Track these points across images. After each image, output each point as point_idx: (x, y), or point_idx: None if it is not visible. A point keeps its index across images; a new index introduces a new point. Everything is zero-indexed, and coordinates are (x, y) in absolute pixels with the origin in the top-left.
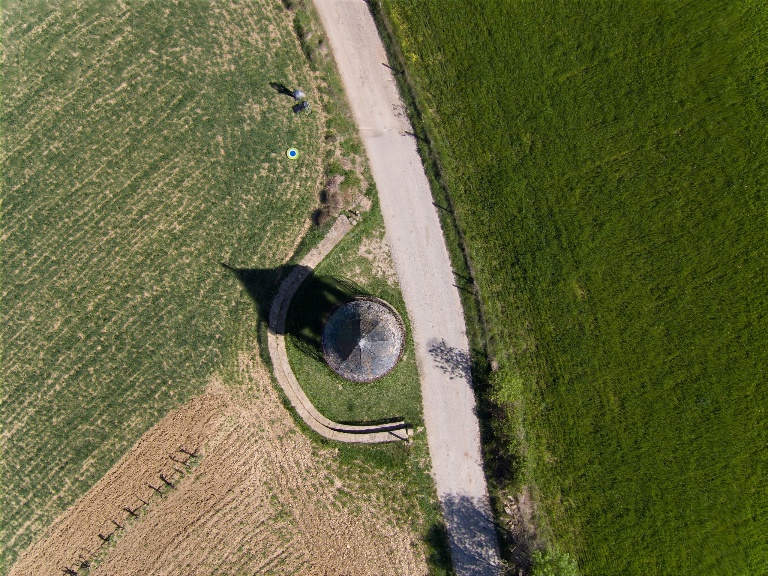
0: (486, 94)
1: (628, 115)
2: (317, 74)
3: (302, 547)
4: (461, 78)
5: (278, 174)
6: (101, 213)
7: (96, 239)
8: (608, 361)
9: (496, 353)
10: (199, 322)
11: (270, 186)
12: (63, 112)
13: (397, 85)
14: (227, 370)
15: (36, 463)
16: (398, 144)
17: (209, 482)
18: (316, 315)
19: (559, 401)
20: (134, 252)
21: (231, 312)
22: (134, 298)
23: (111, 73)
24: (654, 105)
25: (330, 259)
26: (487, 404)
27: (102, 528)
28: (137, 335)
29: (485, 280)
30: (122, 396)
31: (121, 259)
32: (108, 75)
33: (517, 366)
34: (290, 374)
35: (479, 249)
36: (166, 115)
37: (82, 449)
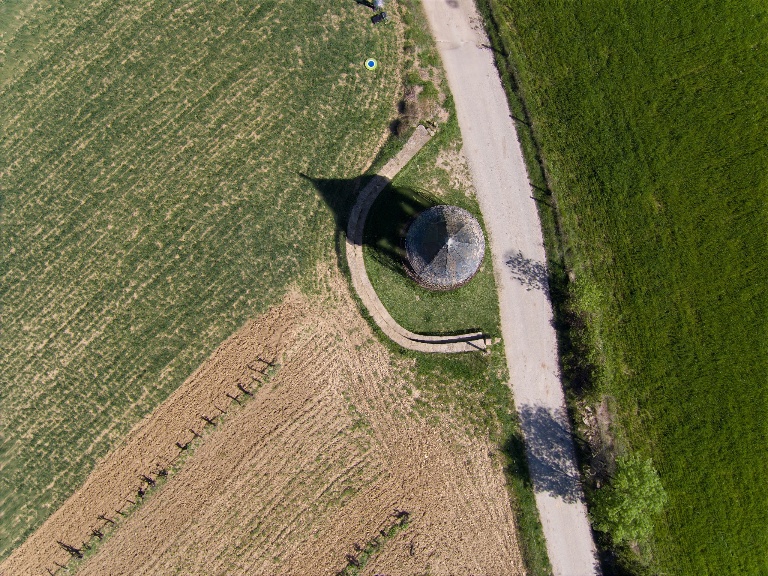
0: (563, 7)
1: (705, 29)
2: None
3: (380, 457)
4: None
5: (356, 84)
6: (179, 122)
7: (174, 148)
8: (685, 274)
9: (573, 265)
10: (277, 232)
11: (348, 96)
12: (142, 21)
13: None
14: (305, 280)
15: (114, 371)
16: (475, 57)
17: (287, 391)
18: (393, 226)
19: (636, 313)
20: (212, 161)
21: (309, 222)
22: (212, 207)
23: None
24: (731, 19)
25: (407, 170)
26: (565, 315)
27: (180, 436)
28: (215, 244)
29: (562, 192)
30: (200, 305)
31: (199, 168)
32: None
33: (594, 278)
34: (368, 284)
35: (556, 161)
36: (244, 25)
37: (160, 357)
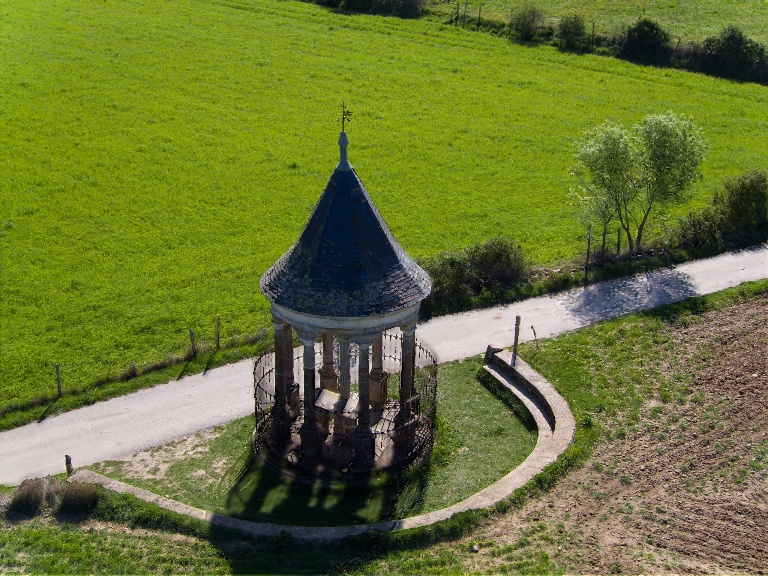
0: None
1: None
2: None
3: None
4: None
5: None
6: None
7: None
8: None
9: None
10: None
11: None
12: None
13: None
14: None
15: None
16: None
17: None
18: (321, 503)
19: None
20: None
21: None
22: None
23: None
24: None
25: None
26: None
27: None
28: None
29: None
30: None
31: None
32: None
33: None
34: None
35: None
36: None
37: None
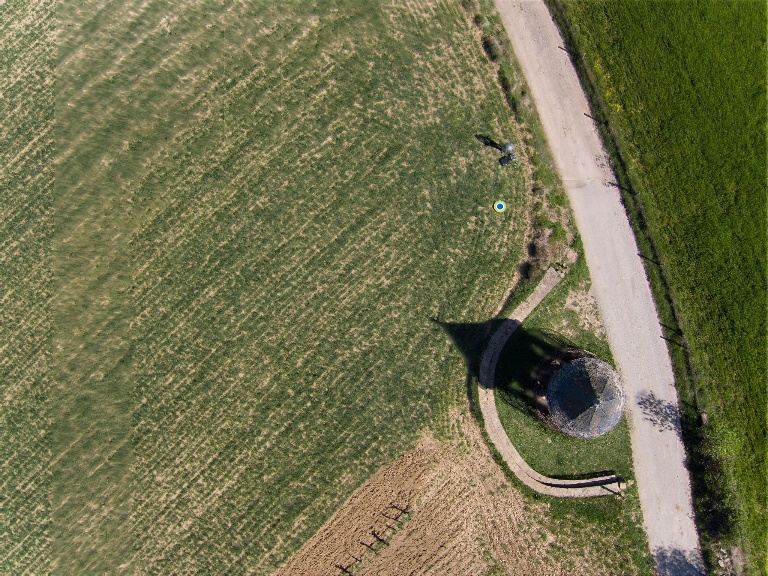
0: (690, 144)
1: None
2: (522, 126)
3: None
4: (664, 128)
5: (486, 227)
6: (309, 268)
7: (304, 294)
8: None
9: (705, 405)
10: (408, 377)
11: (478, 239)
12: (269, 167)
13: (600, 135)
14: (437, 425)
15: (248, 521)
16: (602, 195)
17: (421, 538)
18: (524, 368)
19: None
20: (342, 307)
21: (441, 367)
22: (343, 354)
23: (316, 127)
24: None
25: (537, 312)
26: (698, 457)
27: None
28: (347, 391)
29: (692, 331)
30: (333, 452)
31: (329, 314)
32: (313, 129)
33: (726, 418)
34: (500, 428)
35: (685, 300)
36: (372, 169)
37: (294, 506)
